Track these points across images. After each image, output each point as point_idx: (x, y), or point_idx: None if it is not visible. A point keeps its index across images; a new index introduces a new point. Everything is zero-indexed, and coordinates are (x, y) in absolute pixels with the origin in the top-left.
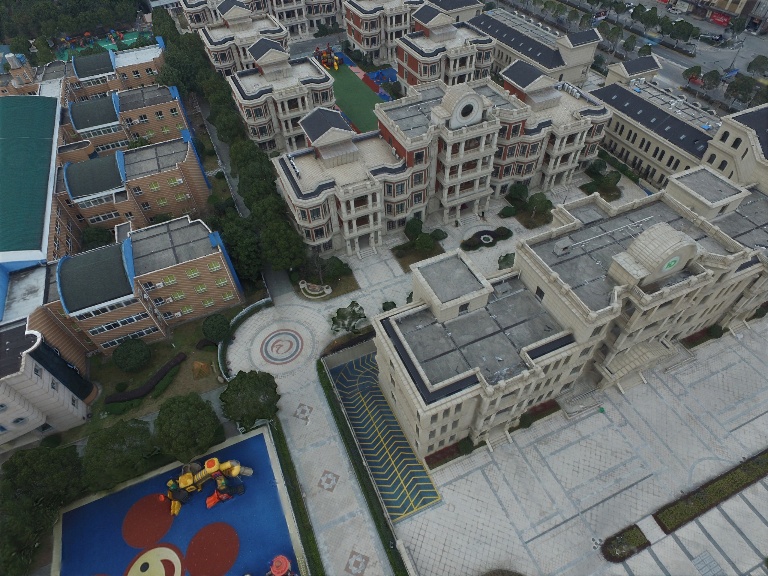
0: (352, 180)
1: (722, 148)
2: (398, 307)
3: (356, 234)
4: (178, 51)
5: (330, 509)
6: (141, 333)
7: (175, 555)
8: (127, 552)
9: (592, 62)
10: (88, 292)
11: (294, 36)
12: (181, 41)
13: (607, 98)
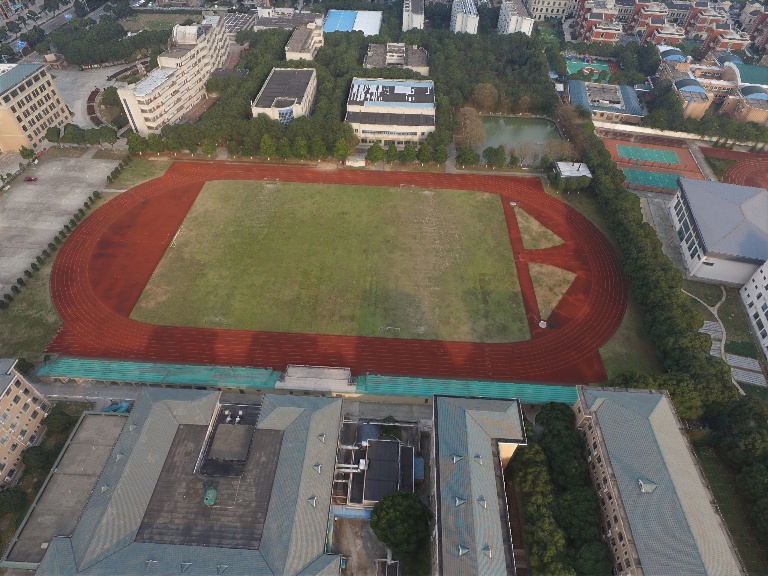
0: None
1: None
2: None
3: None
4: None
5: None
6: None
7: None
8: None
9: None
10: None
11: None
12: None
13: None
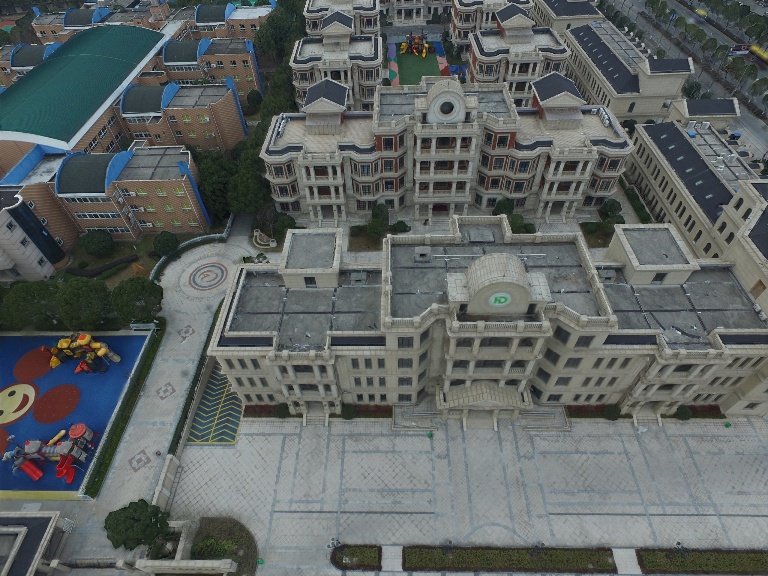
0: (321, 150)
1: (733, 217)
2: (265, 263)
3: (317, 202)
4: (283, 14)
5: (151, 412)
6: (117, 230)
7: (34, 394)
8: (9, 378)
9: (678, 96)
10: (76, 182)
11: (408, 20)
12: (298, 7)
13: (656, 136)
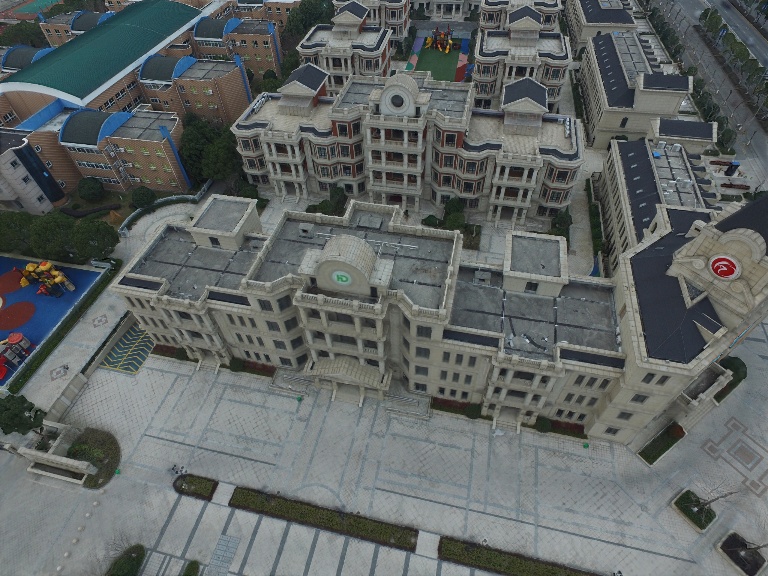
0: (285, 129)
1: None
2: None
3: (280, 177)
4: (318, 0)
5: (82, 336)
6: (110, 180)
7: (1, 305)
8: None
9: (675, 116)
10: (77, 133)
11: (447, 15)
12: None
13: (625, 153)
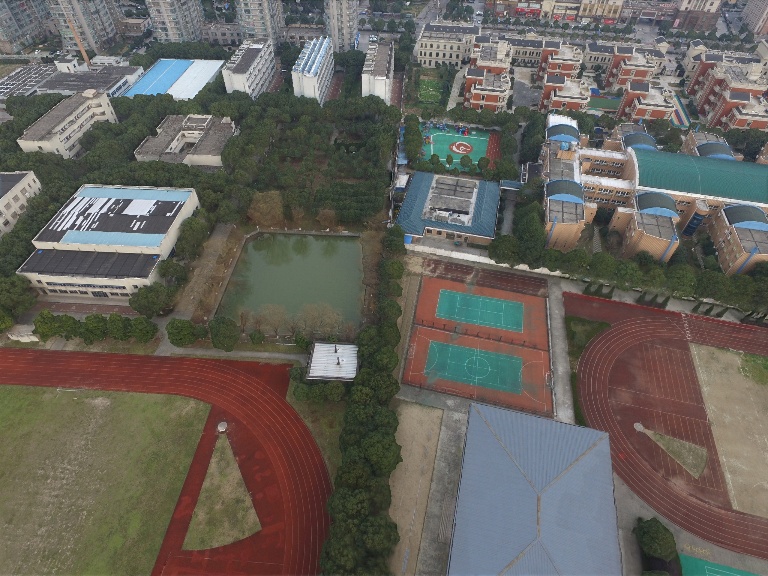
0: (764, 108)
1: None
2: None
3: None
4: None
5: None
6: None
7: None
8: None
9: None
10: None
11: None
12: (524, 113)
13: None
